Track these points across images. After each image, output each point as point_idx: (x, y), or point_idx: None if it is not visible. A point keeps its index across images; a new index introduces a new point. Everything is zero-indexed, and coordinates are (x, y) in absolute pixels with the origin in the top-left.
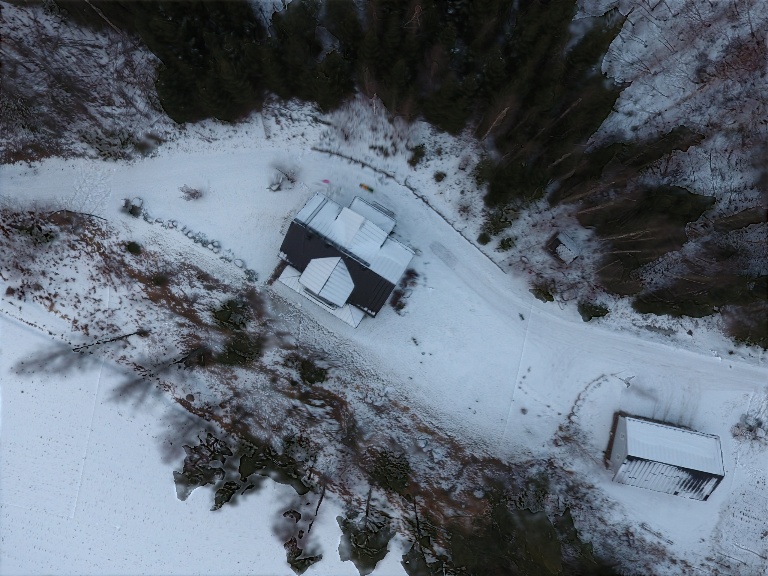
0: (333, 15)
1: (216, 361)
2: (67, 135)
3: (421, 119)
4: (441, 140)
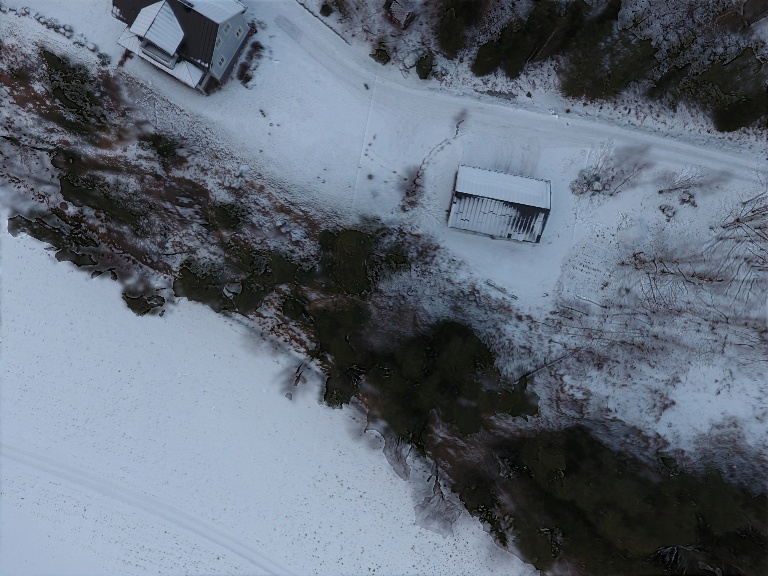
0: None
1: (87, 168)
2: None
3: None
4: None
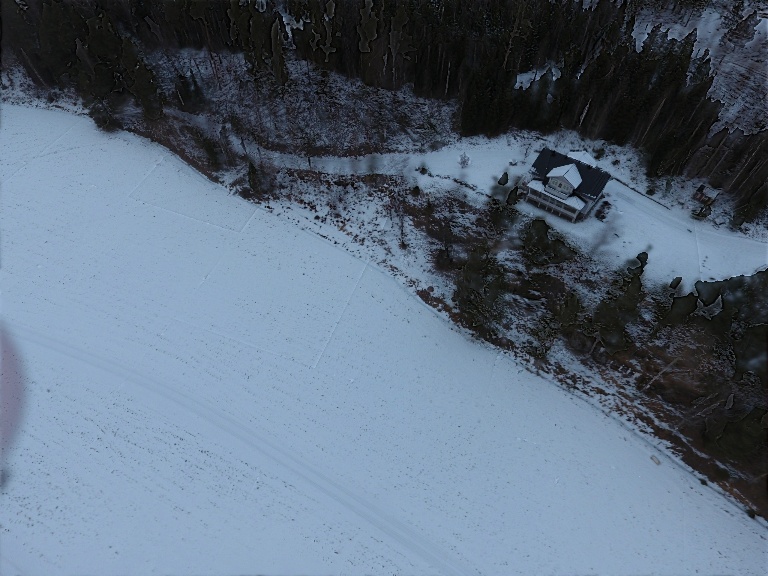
0: (560, 84)
1: (453, 268)
2: (389, 141)
3: (601, 139)
4: (614, 148)
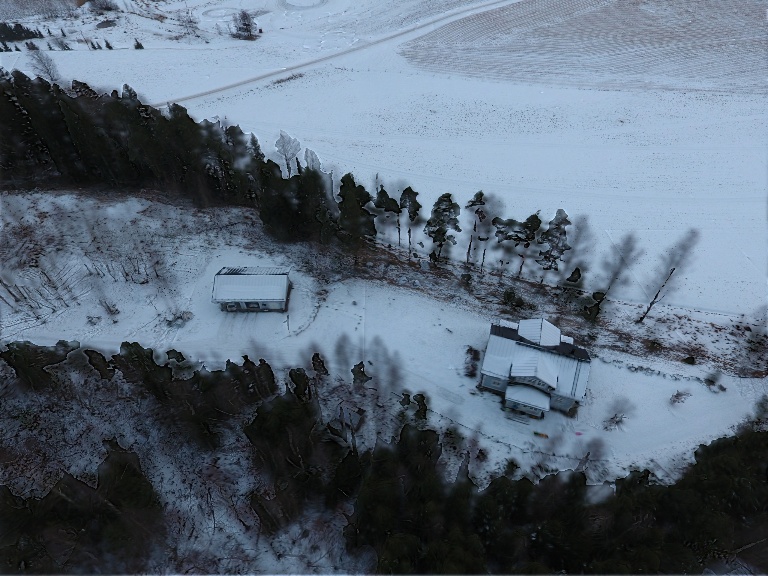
0: None
1: None
2: None
3: None
4: None
